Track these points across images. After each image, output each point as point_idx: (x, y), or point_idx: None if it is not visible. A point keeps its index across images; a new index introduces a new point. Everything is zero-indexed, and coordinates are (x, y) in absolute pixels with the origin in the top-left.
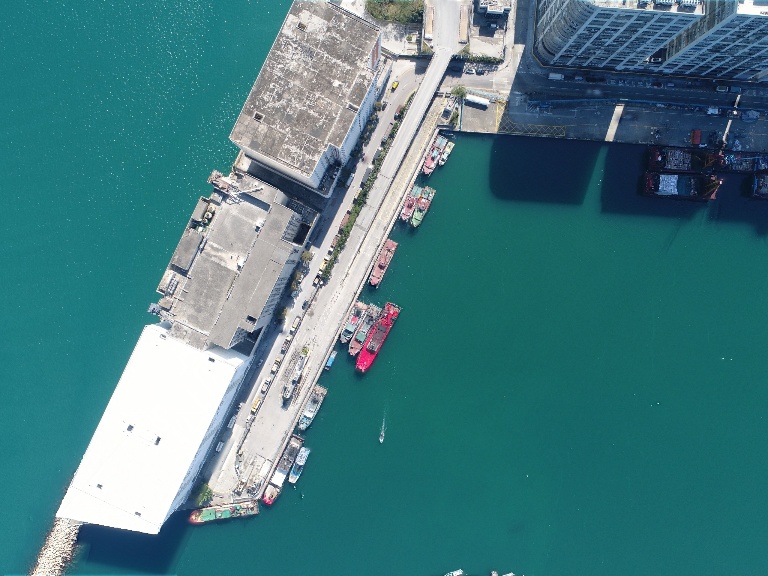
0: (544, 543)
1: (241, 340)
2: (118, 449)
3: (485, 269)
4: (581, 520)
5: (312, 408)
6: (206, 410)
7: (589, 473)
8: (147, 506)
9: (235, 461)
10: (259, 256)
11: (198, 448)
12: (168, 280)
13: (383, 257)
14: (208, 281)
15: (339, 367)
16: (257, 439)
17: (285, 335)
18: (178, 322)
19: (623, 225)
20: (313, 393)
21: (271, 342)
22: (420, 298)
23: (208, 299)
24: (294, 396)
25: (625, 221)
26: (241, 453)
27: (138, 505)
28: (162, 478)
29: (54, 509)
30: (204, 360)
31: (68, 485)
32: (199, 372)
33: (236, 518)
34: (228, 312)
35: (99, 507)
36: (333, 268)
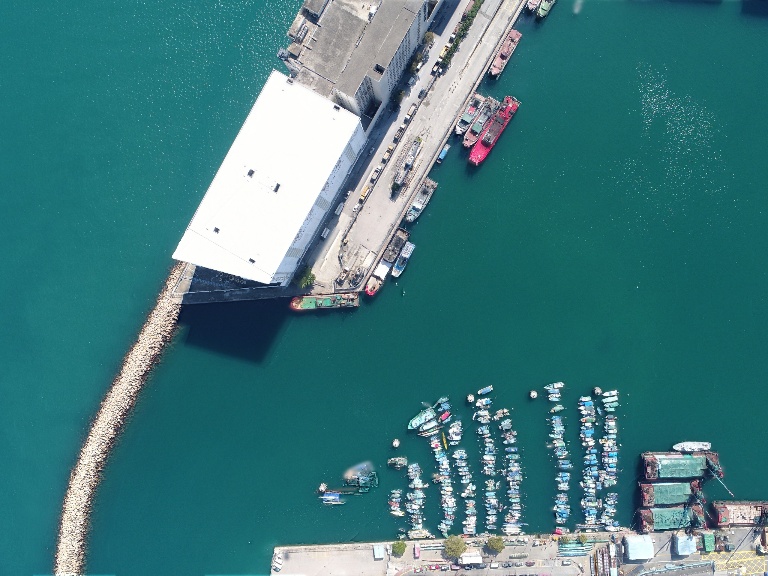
0: (653, 362)
1: (359, 114)
2: (237, 193)
3: (611, 68)
4: (695, 340)
5: (422, 199)
6: (327, 159)
7: (707, 292)
8: (261, 254)
9: (339, 250)
10: (392, 3)
11: (316, 199)
12: (299, 24)
13: (506, 46)
14: (338, 30)
15: (451, 162)
16: (363, 229)
17: (399, 124)
18: (306, 68)
19: (764, 28)
20: (423, 185)
21: (384, 130)
22: (540, 95)
23: (336, 49)
24: (403, 187)
25: (766, 24)
26: (346, 241)
27: (252, 253)
28: (278, 226)
29: (157, 289)
30: (329, 108)
31: (173, 265)
32: (323, 120)
33: (335, 310)
34: (357, 60)
35: (214, 252)
36: (453, 57)
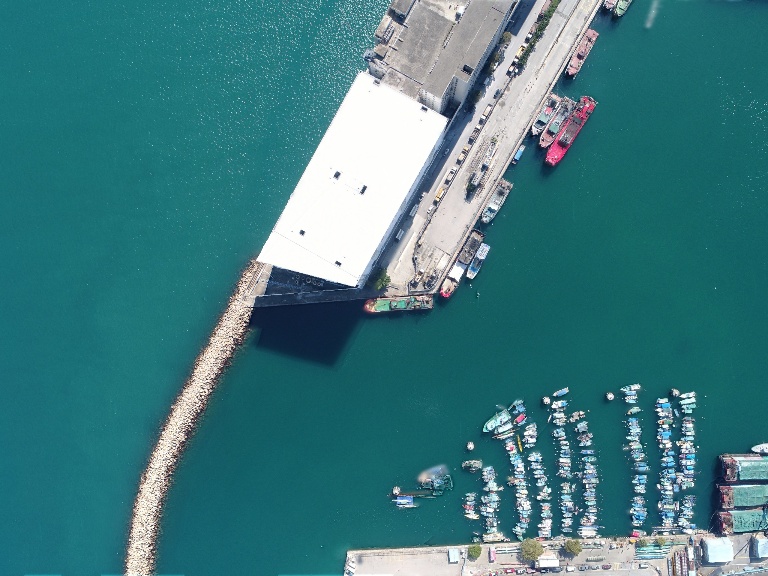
0: (731, 363)
1: None
2: (323, 196)
3: (688, 67)
4: None
5: (498, 200)
6: (414, 161)
7: None
8: (348, 256)
9: (414, 252)
10: (481, 3)
11: None
12: (386, 25)
13: (583, 46)
14: (424, 30)
15: (526, 162)
16: (437, 231)
17: (474, 125)
18: (393, 68)
19: None
20: (499, 186)
21: (459, 131)
22: (617, 95)
23: (423, 49)
24: (479, 188)
25: None
26: (421, 243)
27: (338, 255)
28: (365, 228)
29: (228, 291)
30: (416, 109)
31: (244, 268)
32: (411, 121)
33: (409, 312)
34: (444, 60)
35: (300, 254)
36: (529, 57)
